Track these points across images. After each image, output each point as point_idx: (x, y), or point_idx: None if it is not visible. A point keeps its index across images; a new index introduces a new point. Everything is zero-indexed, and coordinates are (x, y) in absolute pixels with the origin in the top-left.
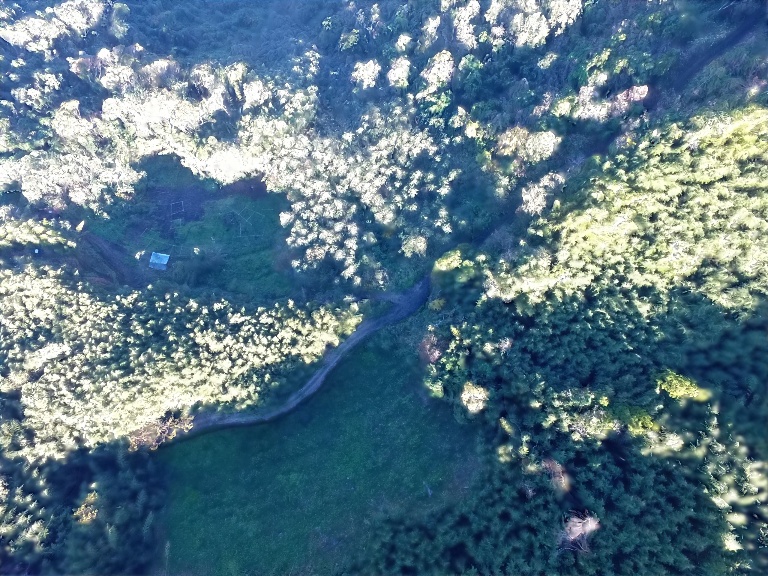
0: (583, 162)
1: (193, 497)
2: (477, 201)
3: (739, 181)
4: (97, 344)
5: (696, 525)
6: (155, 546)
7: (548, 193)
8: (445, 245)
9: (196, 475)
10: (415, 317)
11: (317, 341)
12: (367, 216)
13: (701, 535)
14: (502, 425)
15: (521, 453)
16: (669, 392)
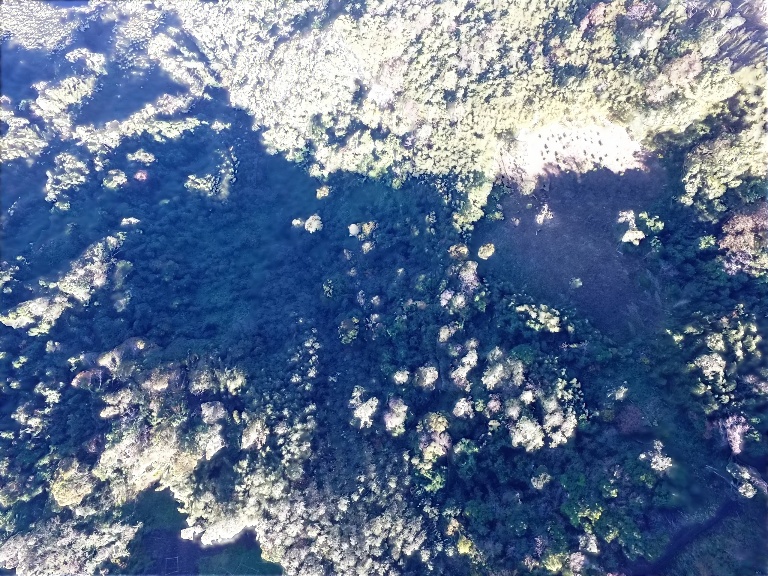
0: None
1: None
2: None
3: None
4: None
5: None
6: None
7: None
8: None
9: None
10: None
11: None
12: None
13: None
14: None
15: None
16: None
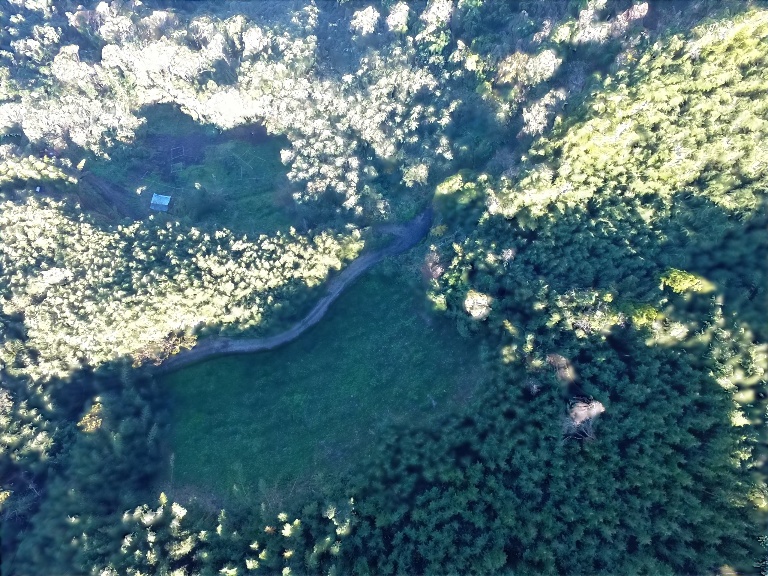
0: (584, 81)
1: (197, 419)
2: (478, 132)
3: (741, 85)
4: (99, 270)
5: (702, 407)
6: (160, 460)
7: (549, 111)
8: (446, 172)
9: (200, 399)
10: (417, 248)
11: (319, 264)
12: (368, 153)
13: (707, 415)
14: (506, 327)
15: (525, 351)
16: (673, 288)
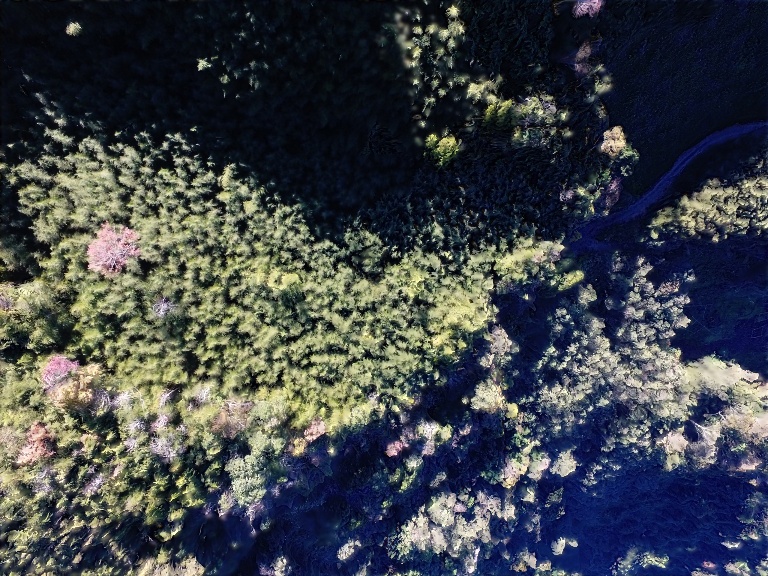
0: None
1: None
2: None
3: (341, 360)
4: None
5: None
6: None
7: None
8: (564, 296)
9: None
10: None
11: (707, 200)
12: None
13: None
14: None
15: None
16: None
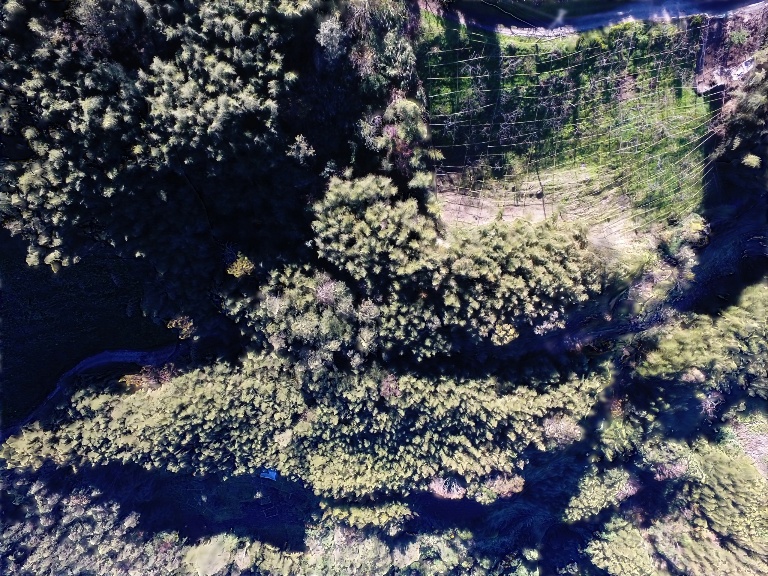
0: None
1: None
2: None
3: None
4: None
5: None
6: None
7: None
8: None
9: None
10: None
11: None
12: None
13: None
14: None
15: None
16: None
